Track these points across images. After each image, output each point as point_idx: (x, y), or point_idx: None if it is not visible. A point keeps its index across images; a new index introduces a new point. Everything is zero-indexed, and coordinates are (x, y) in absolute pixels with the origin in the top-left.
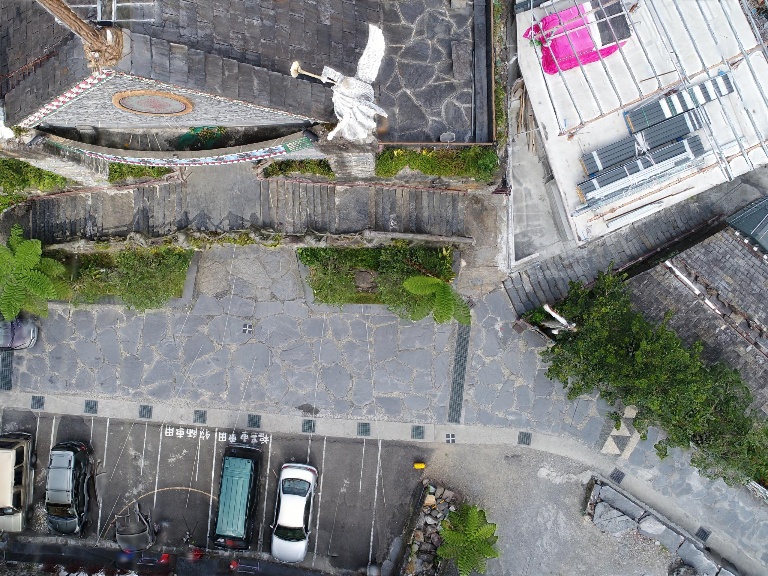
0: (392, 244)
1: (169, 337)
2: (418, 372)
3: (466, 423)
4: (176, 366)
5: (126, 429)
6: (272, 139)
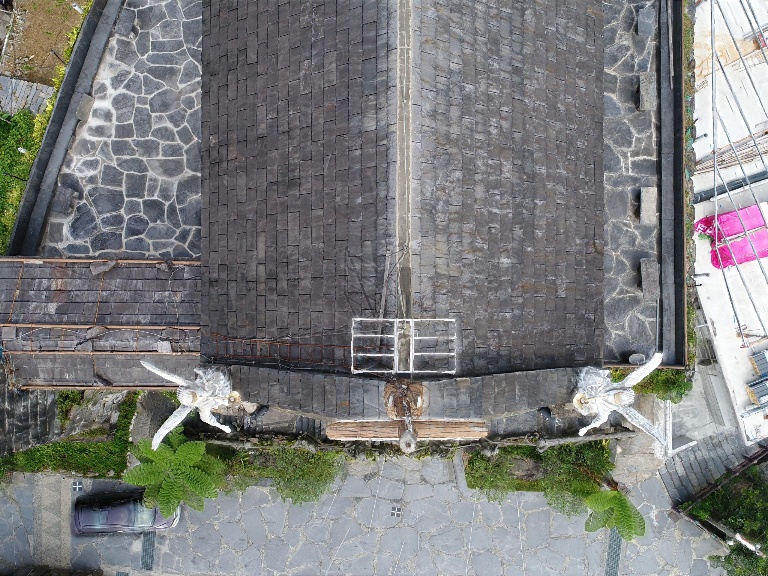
0: None
1: (315, 519)
2: (571, 560)
3: None
4: (322, 549)
5: None
6: None
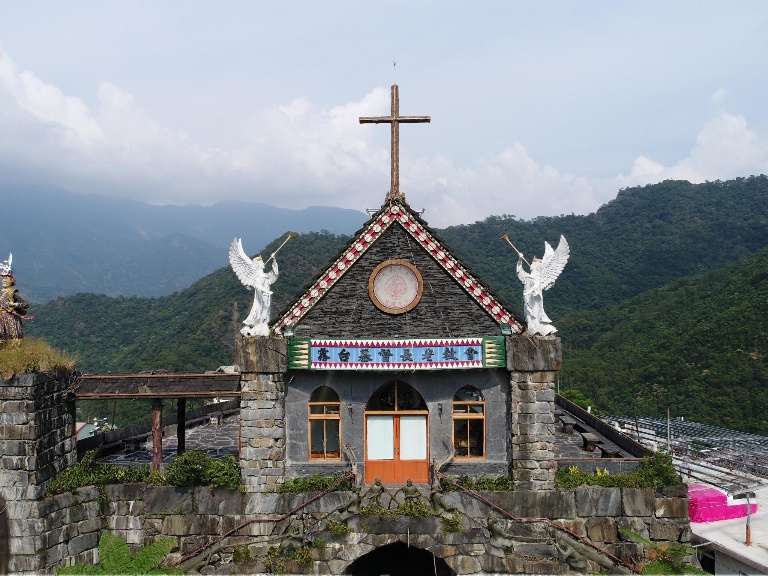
0: None
1: None
2: None
3: None
4: None
5: None
6: None
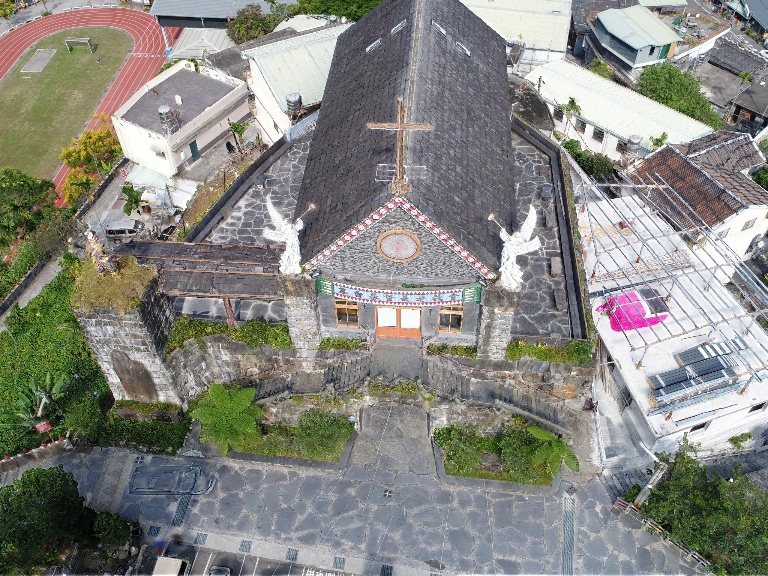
0: (512, 424)
1: (322, 495)
2: (532, 540)
3: None
4: (324, 518)
5: (272, 568)
6: (458, 285)
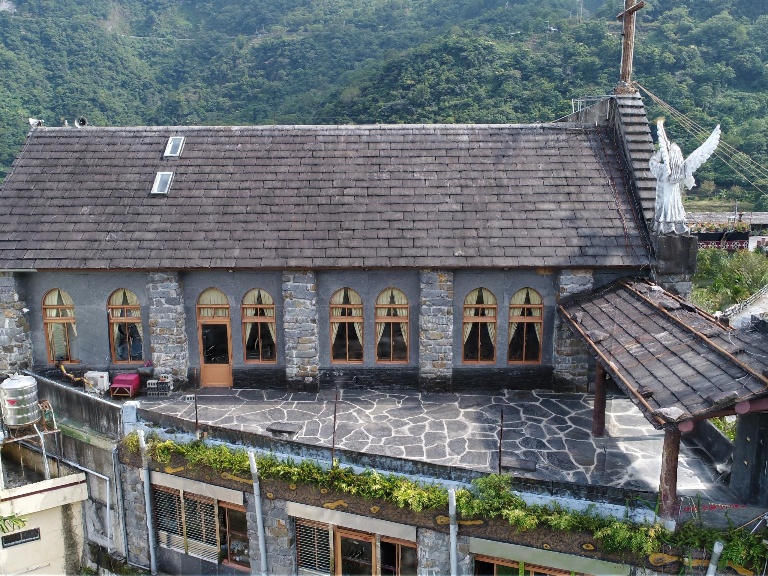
0: None
1: None
2: None
3: None
4: None
5: None
6: None
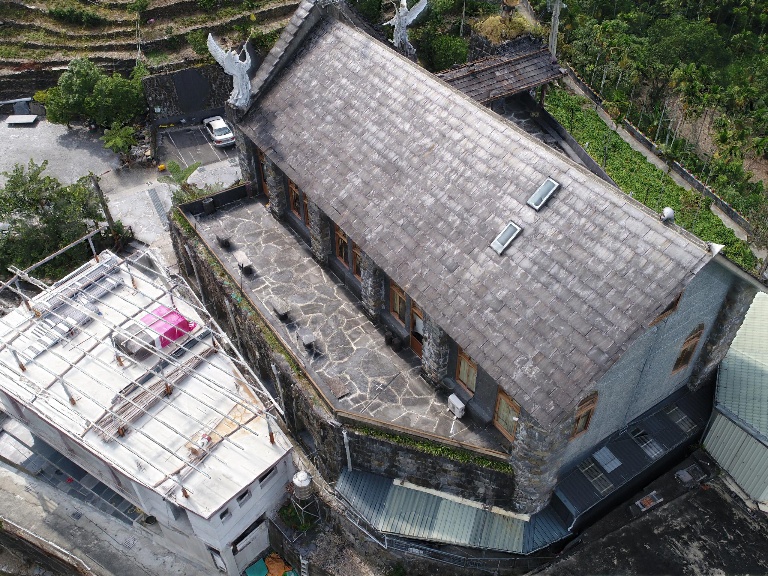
0: None
1: None
2: None
3: (144, 191)
4: None
5: None
6: None
